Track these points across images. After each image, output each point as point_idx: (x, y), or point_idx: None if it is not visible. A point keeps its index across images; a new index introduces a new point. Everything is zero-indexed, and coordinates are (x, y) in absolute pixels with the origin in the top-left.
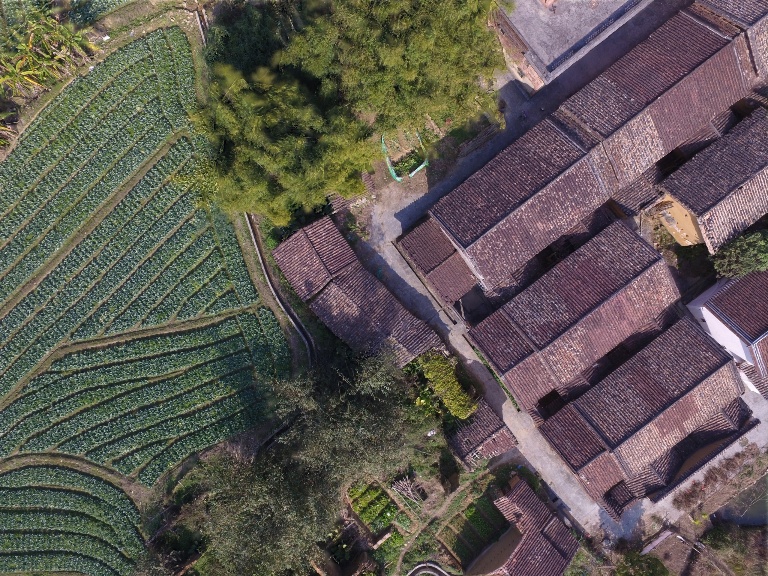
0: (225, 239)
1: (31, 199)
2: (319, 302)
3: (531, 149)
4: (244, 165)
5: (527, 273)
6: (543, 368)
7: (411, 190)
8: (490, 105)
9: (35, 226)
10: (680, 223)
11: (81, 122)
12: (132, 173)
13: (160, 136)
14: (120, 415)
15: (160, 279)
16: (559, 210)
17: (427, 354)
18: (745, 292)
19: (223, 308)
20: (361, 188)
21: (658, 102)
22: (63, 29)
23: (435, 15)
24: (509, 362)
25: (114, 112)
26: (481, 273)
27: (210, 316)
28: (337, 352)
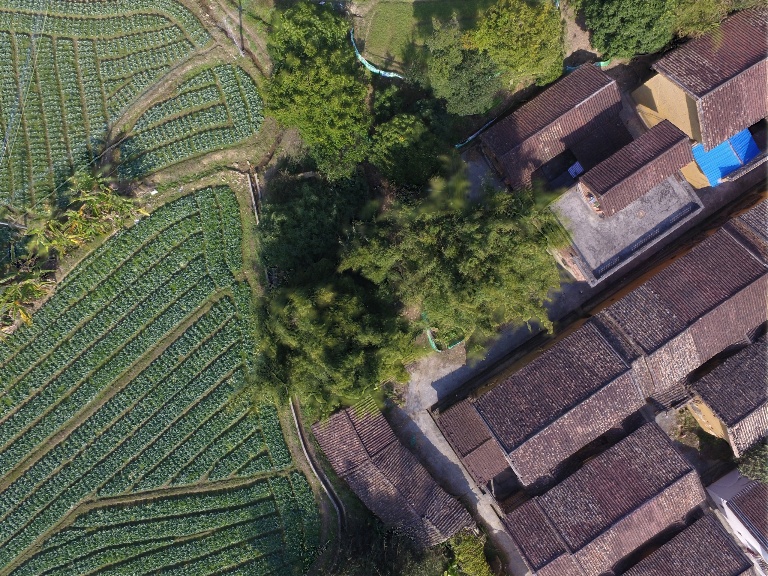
0: (262, 402)
1: (65, 350)
2: (355, 477)
3: (575, 353)
4: (301, 375)
5: (561, 463)
6: (573, 564)
7: (449, 361)
8: (542, 320)
9: (68, 378)
10: (707, 417)
11: (123, 276)
12: (171, 329)
13: (203, 294)
14: (143, 574)
15: (193, 438)
16: (599, 416)
17: (459, 535)
18: (766, 495)
19: (256, 471)
20: (407, 377)
21: (699, 322)
22: (116, 198)
23: (502, 256)
24: (541, 559)
25: (157, 268)
26: (520, 472)
27: (242, 477)
28: (368, 523)
